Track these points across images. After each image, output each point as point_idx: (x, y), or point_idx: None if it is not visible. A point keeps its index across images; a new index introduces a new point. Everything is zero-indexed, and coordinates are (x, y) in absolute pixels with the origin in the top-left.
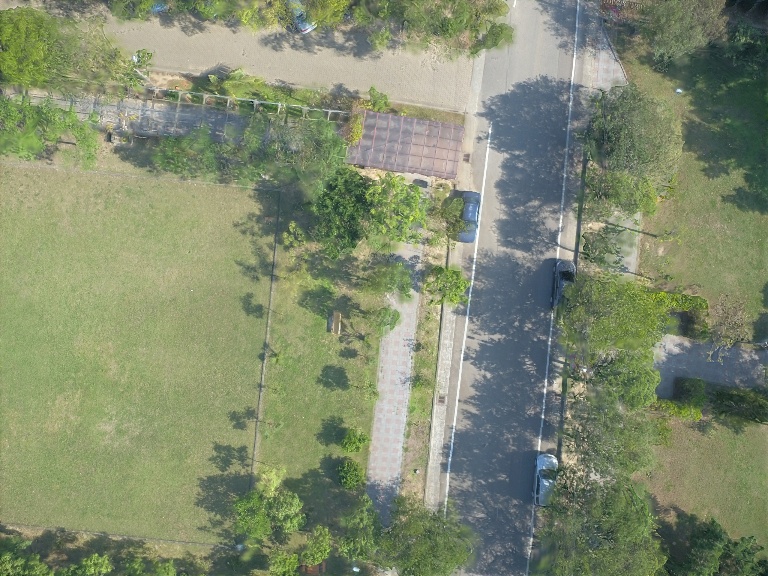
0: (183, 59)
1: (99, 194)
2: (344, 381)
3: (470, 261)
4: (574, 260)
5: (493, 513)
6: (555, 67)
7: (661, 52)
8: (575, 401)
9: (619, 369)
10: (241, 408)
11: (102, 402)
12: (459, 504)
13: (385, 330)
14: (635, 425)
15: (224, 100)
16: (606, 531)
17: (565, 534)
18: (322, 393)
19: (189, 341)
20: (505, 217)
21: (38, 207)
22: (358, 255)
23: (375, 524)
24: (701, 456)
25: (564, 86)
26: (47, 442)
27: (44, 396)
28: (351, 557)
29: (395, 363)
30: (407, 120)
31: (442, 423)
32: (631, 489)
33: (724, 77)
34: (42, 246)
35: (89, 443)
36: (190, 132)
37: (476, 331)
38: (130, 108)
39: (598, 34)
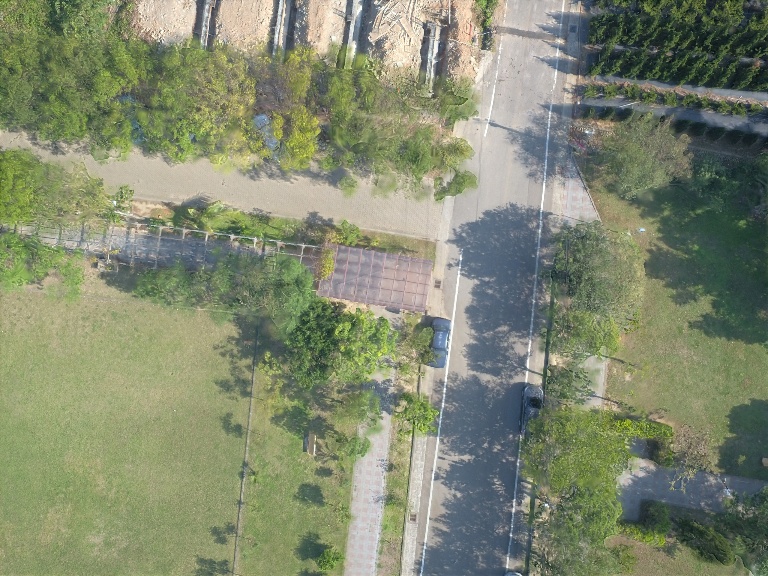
0: (166, 189)
1: (87, 318)
2: (319, 499)
3: (441, 384)
4: (542, 384)
5: None
6: (525, 195)
7: None
8: (542, 521)
9: (580, 503)
10: (221, 524)
11: (91, 516)
12: None
13: None
14: (595, 559)
15: None
16: None
17: None
18: (298, 510)
19: (172, 459)
20: (475, 342)
21: (30, 330)
22: (333, 378)
23: None
24: (665, 575)
25: (534, 214)
26: (40, 553)
27: (37, 509)
28: None
29: (368, 482)
30: (378, 255)
31: (413, 540)
32: None
33: (692, 204)
34: (34, 367)
35: (79, 554)
36: (172, 259)
37: (447, 452)
38: (116, 236)
39: (567, 162)
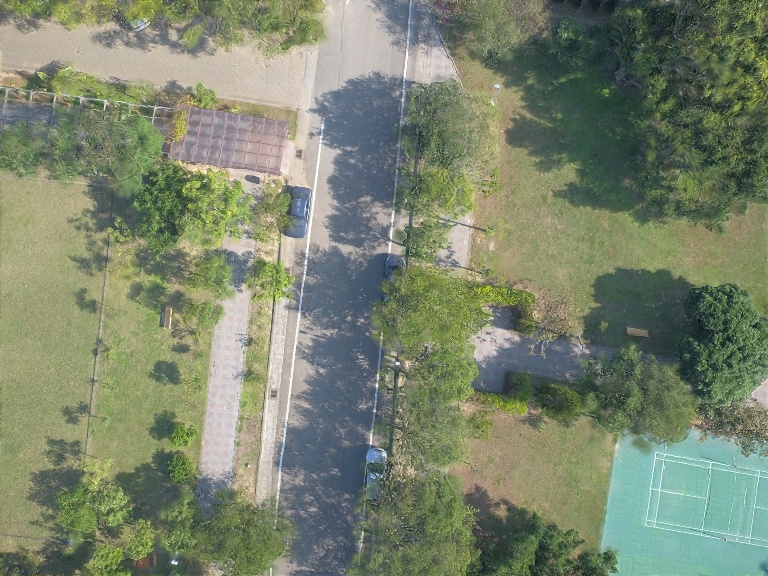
0: (18, 57)
1: None
2: (176, 376)
3: (302, 256)
4: (406, 255)
5: (325, 507)
6: (387, 64)
7: (488, 48)
8: (407, 395)
9: (433, 362)
10: (74, 403)
11: None
12: (291, 498)
13: (217, 325)
14: (447, 418)
15: None
16: (412, 523)
17: (378, 526)
18: (155, 388)
19: (23, 336)
20: (337, 212)
21: None
22: (191, 250)
23: (195, 517)
24: (531, 450)
25: (396, 82)
26: None
27: None
28: (174, 550)
29: (227, 358)
30: (231, 116)
31: (274, 417)
32: (441, 481)
33: (555, 73)
34: None
35: None
36: (24, 129)
37: (308, 326)
38: None
39: (430, 31)
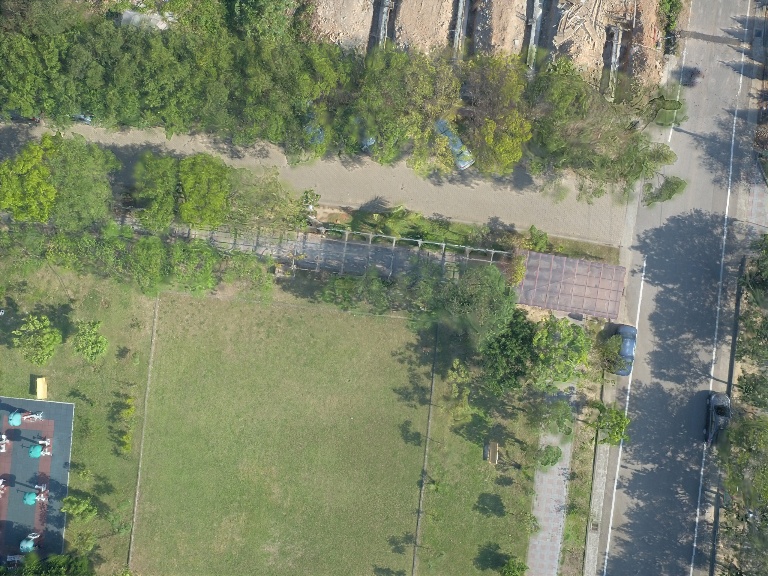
0: (343, 193)
1: (262, 323)
2: (500, 508)
3: (624, 392)
4: (727, 392)
5: None
6: (709, 201)
7: None
8: (727, 530)
9: None
10: (400, 533)
11: (266, 525)
12: None
13: None
14: None
15: (390, 240)
16: None
17: None
18: (478, 519)
19: (349, 467)
20: (659, 349)
21: (203, 335)
22: None
23: None
24: None
25: (718, 220)
26: (213, 562)
27: (210, 518)
28: None
29: (550, 491)
30: (569, 261)
31: (595, 550)
32: None
33: None
34: (207, 373)
35: (253, 564)
36: (351, 265)
37: (629, 460)
38: (292, 240)
39: (753, 168)
